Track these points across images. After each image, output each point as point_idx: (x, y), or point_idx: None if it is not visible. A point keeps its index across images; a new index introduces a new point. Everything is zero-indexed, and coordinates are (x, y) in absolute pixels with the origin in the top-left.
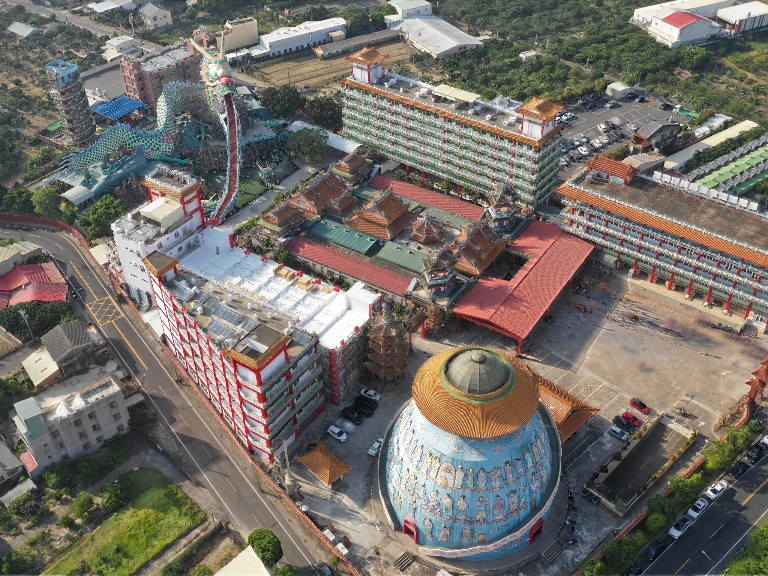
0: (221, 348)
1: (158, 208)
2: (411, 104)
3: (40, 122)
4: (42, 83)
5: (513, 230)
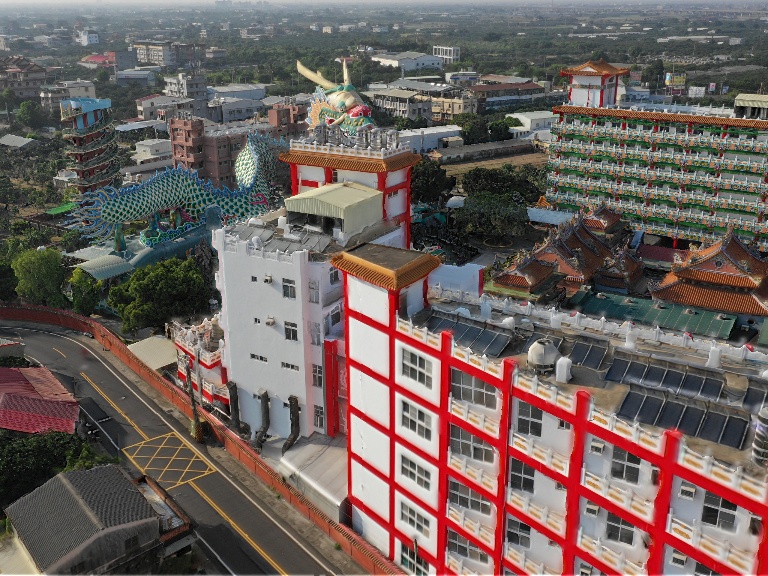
0: (766, 462)
1: (330, 191)
2: (700, 120)
3: (33, 213)
4: (40, 179)
5: None
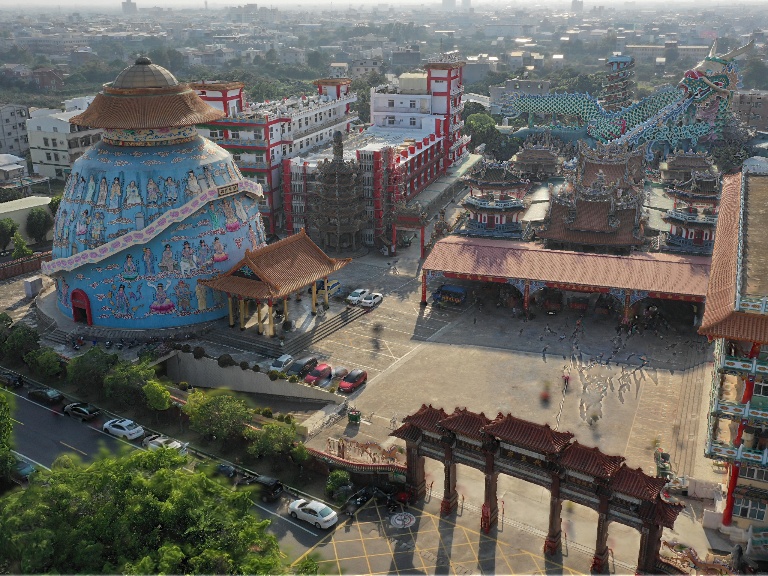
0: None
1: None
2: None
3: None
4: None
5: None
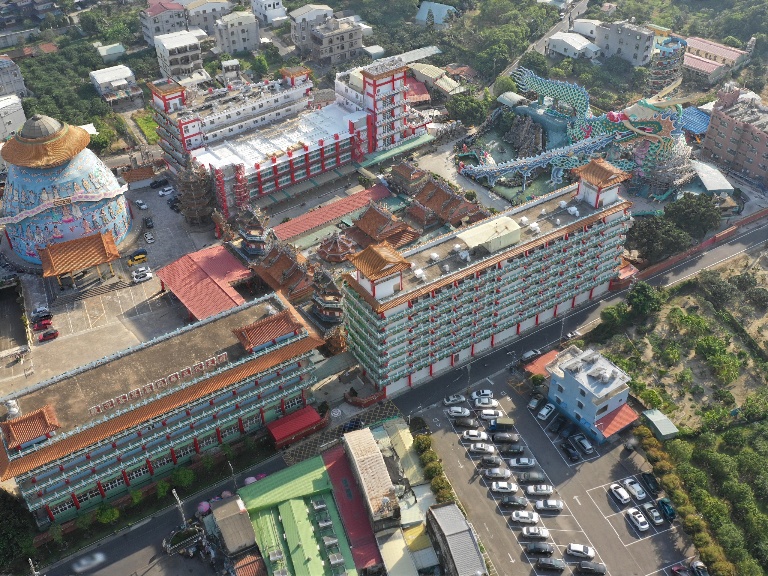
0: None
1: None
2: None
3: None
4: None
5: (312, 315)
